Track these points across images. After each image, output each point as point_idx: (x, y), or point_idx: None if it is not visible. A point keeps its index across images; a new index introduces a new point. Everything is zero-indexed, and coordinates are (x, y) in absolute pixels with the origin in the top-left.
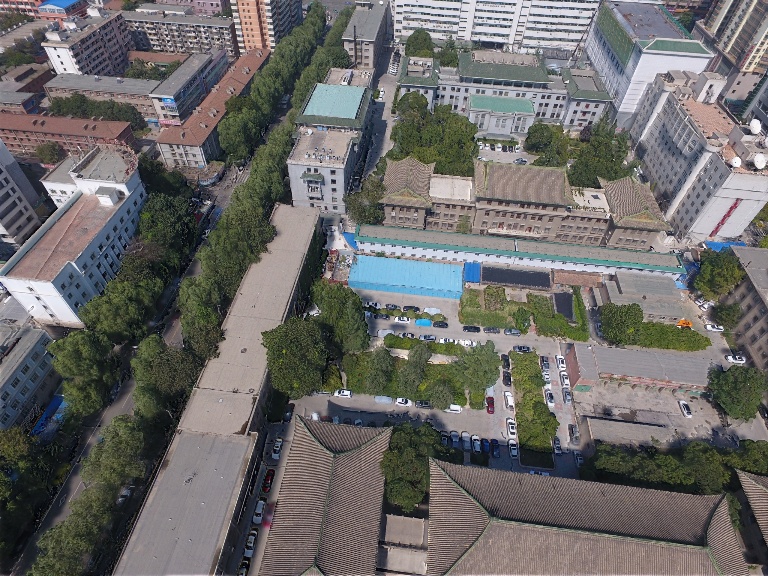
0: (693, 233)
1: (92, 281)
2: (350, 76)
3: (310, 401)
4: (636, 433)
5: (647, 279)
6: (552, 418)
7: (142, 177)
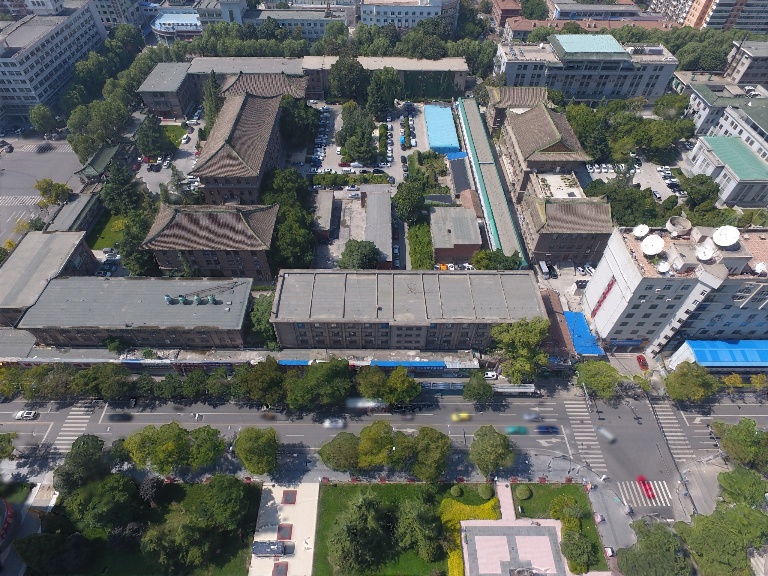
0: (585, 296)
1: (377, 23)
2: (650, 50)
3: (339, 109)
4: (324, 210)
5: (471, 226)
6: (331, 175)
7: (462, 18)
